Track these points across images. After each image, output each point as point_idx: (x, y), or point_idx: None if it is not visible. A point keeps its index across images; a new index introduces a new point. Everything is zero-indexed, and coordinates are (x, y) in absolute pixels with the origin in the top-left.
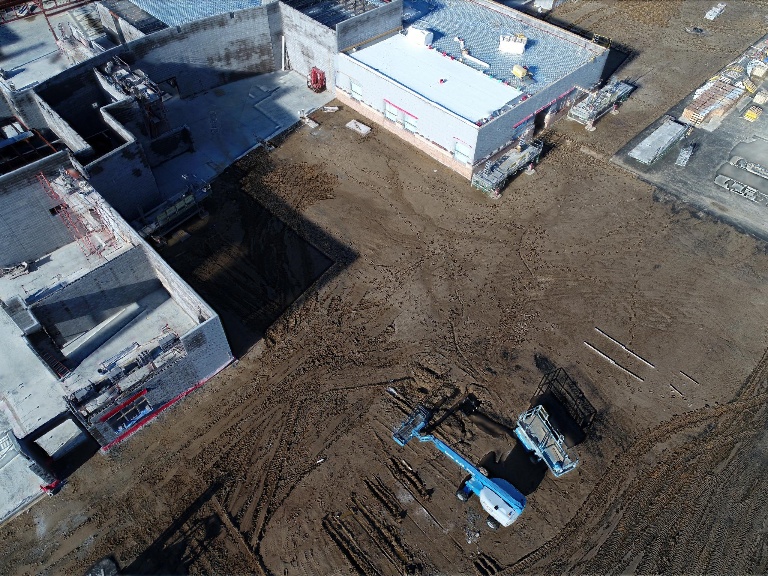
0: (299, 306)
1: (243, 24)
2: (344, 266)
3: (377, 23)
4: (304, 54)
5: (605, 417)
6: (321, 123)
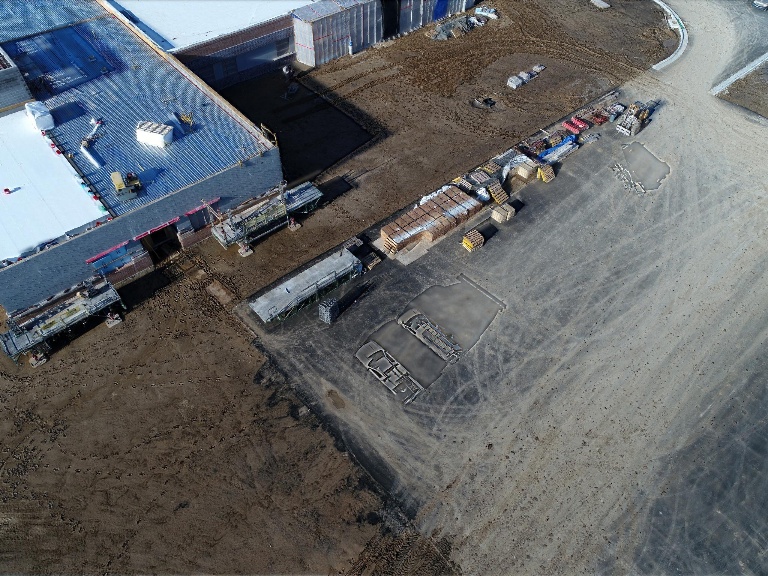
0: None
1: None
2: None
3: None
4: None
5: None
6: None
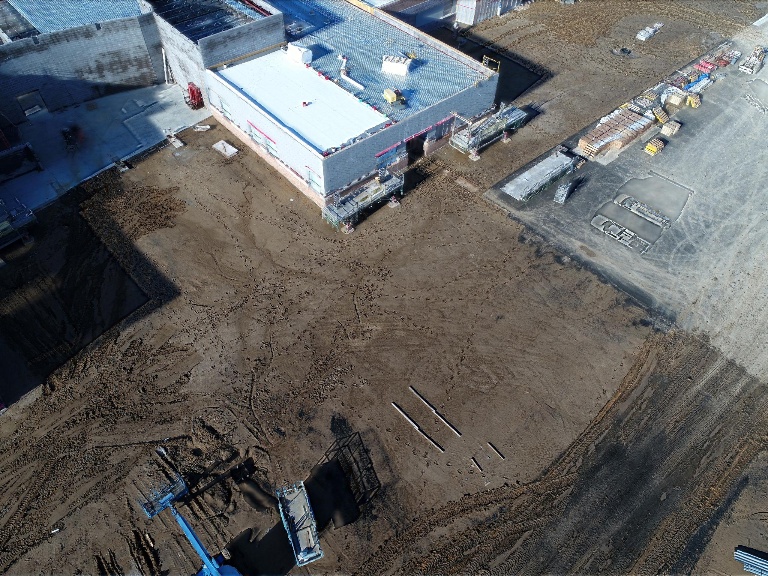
0: (94, 348)
1: (113, 36)
2: (159, 304)
3: (252, 38)
4: (181, 68)
5: (388, 493)
6: (187, 143)
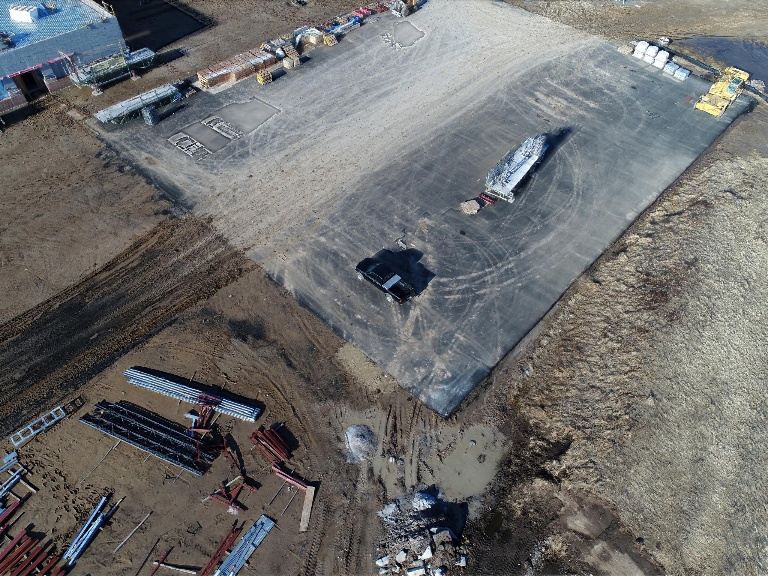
0: None
1: None
2: None
3: None
4: None
5: None
6: None
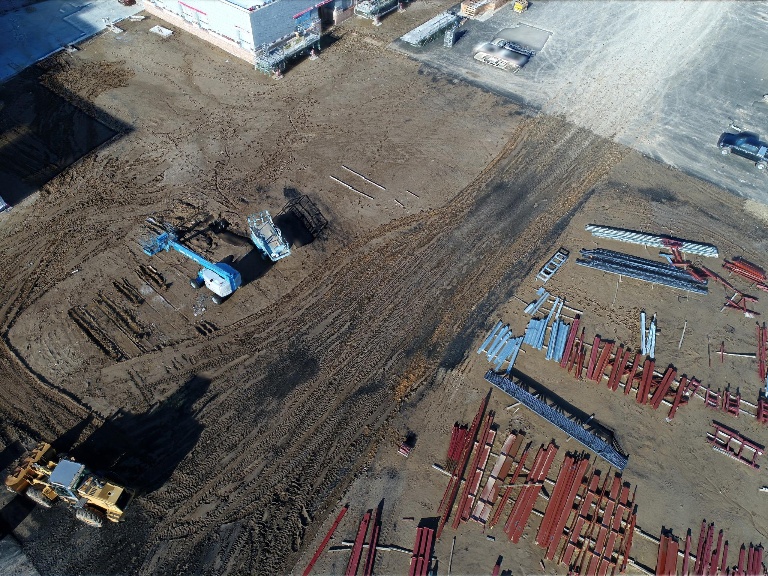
0: (77, 166)
1: None
2: (126, 135)
3: None
4: None
5: (334, 225)
6: (126, 30)
